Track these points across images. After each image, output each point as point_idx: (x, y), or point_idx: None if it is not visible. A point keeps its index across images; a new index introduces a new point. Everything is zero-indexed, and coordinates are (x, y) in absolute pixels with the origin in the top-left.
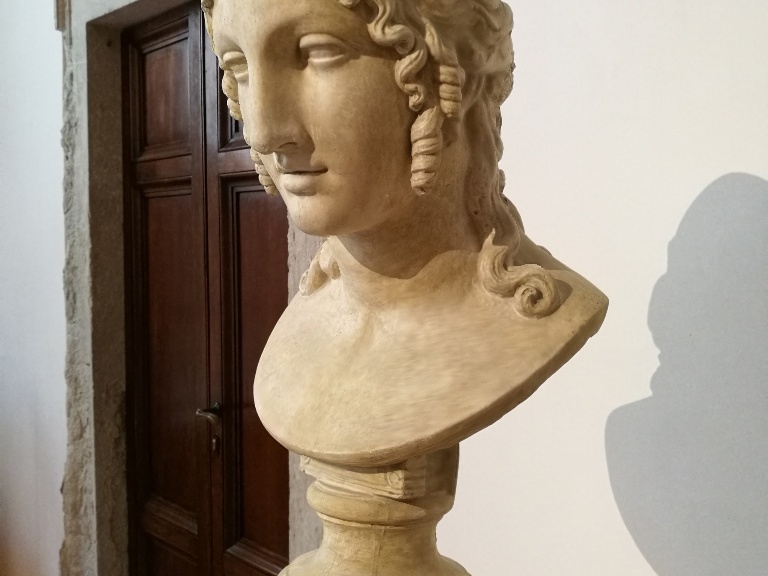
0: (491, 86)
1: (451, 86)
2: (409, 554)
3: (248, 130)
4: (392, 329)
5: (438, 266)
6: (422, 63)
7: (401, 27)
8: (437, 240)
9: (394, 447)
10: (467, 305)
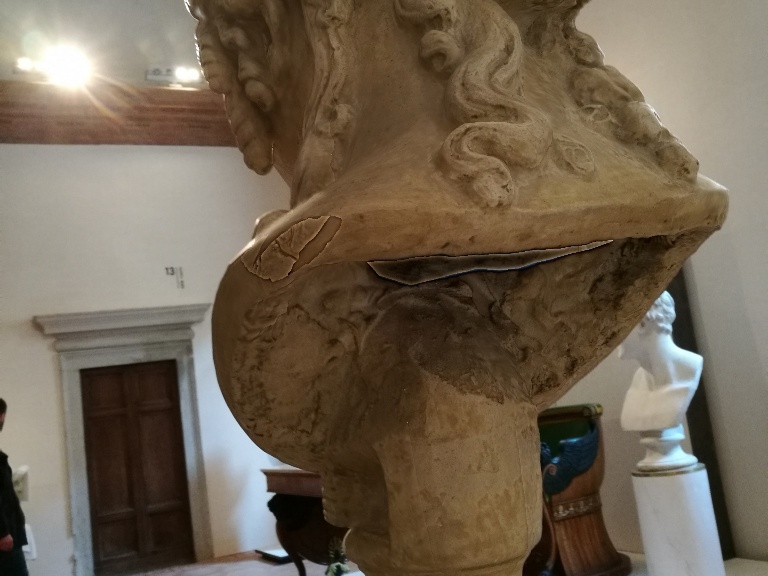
0: None
1: None
2: None
3: None
4: None
5: None
6: None
7: None
8: None
9: None
10: None
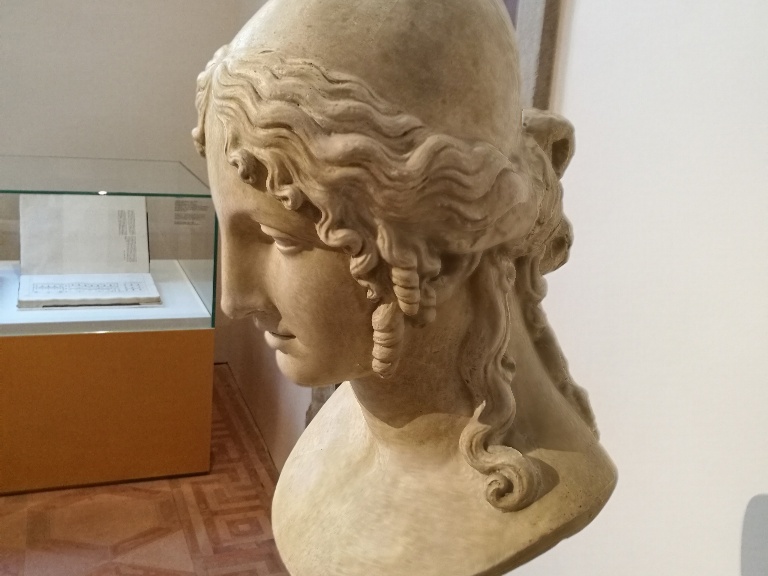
0: (507, 247)
1: (404, 289)
2: None
3: None
4: (384, 465)
5: (423, 425)
6: (370, 266)
7: (344, 233)
8: (422, 402)
9: None
10: (449, 468)
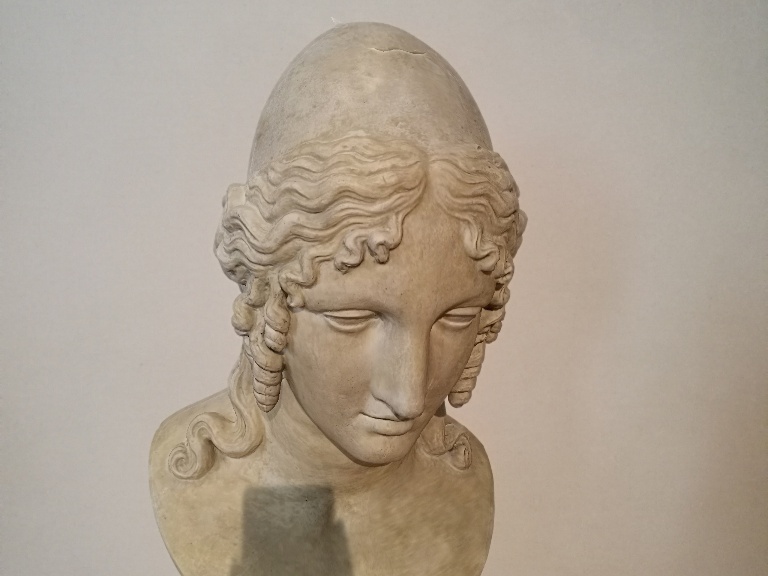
0: None
1: None
2: None
3: (331, 375)
4: (364, 509)
5: None
6: None
7: None
8: None
9: None
10: (417, 470)
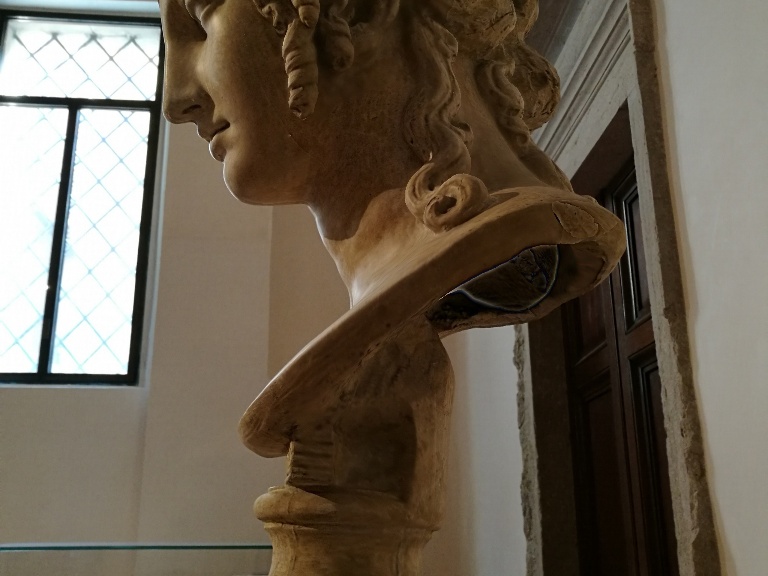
0: (437, 11)
1: None
2: (328, 571)
3: None
4: None
5: (375, 211)
6: None
7: None
8: (369, 181)
9: (258, 398)
10: (405, 248)
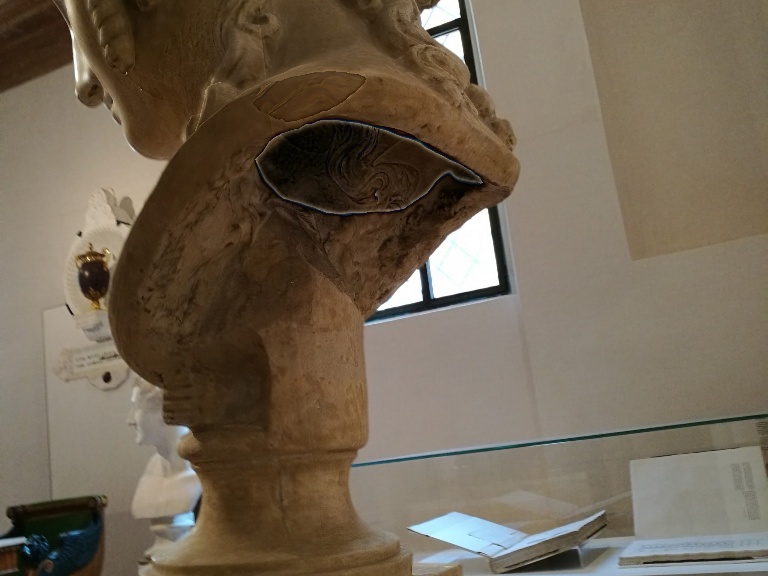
0: None
1: None
2: (216, 505)
3: None
4: None
5: None
6: None
7: None
8: None
9: None
10: None
